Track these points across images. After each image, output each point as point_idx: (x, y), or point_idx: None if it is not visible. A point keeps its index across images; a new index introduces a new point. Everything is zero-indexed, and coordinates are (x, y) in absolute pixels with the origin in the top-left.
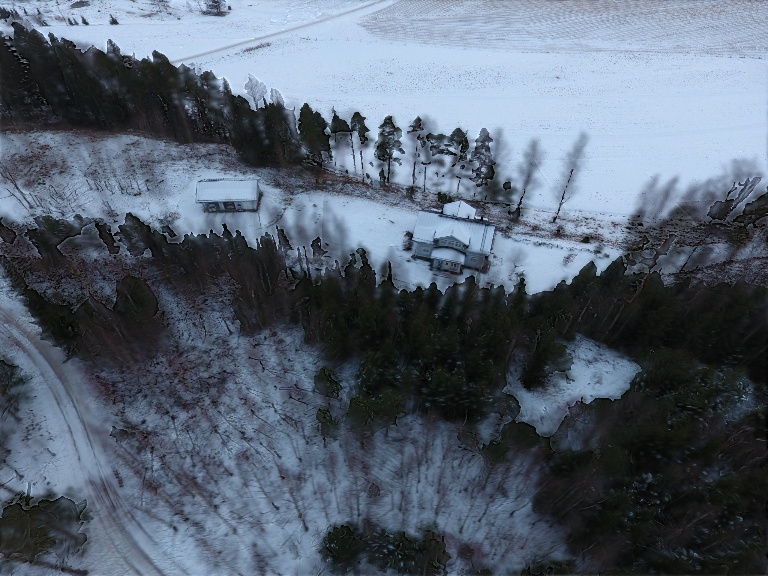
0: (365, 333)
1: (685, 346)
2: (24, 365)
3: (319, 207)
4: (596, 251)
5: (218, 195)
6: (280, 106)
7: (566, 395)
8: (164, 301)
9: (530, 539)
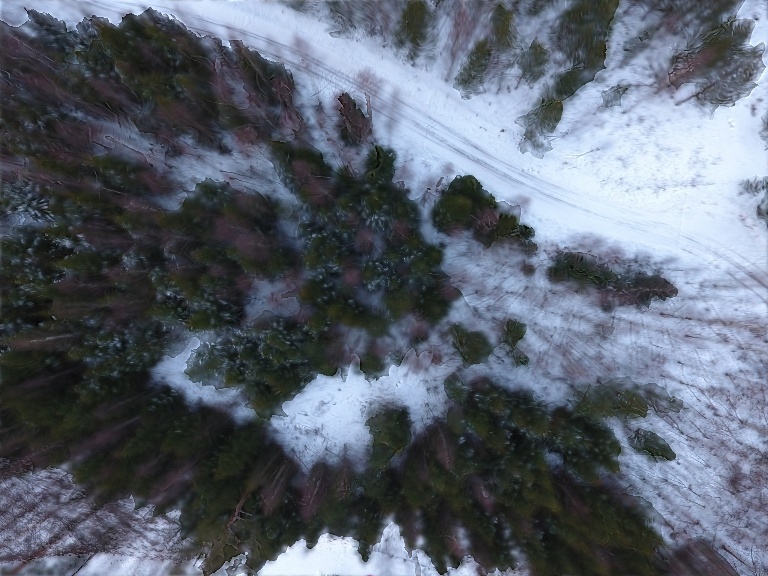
0: (607, 503)
1: (210, 425)
2: None
3: None
4: None
5: None
6: None
7: (367, 396)
8: None
9: (469, 270)
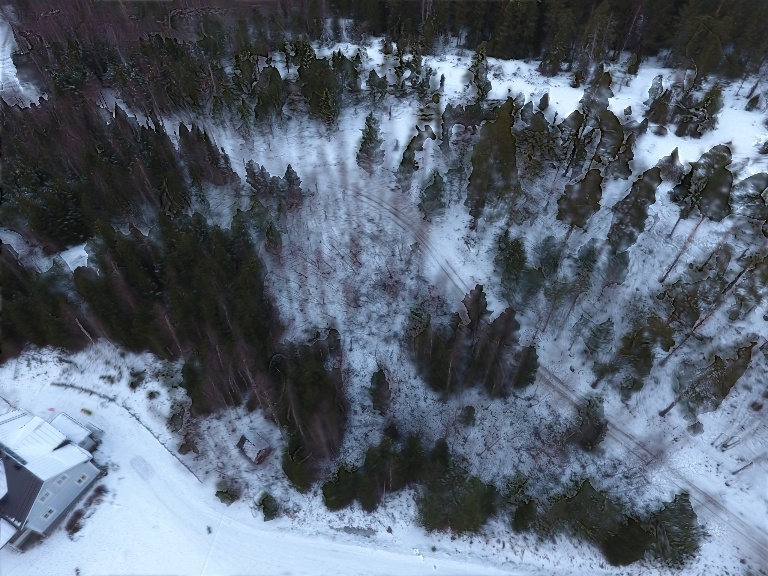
0: None
1: None
2: None
3: None
4: None
5: None
6: None
7: None
8: (430, 425)
9: None
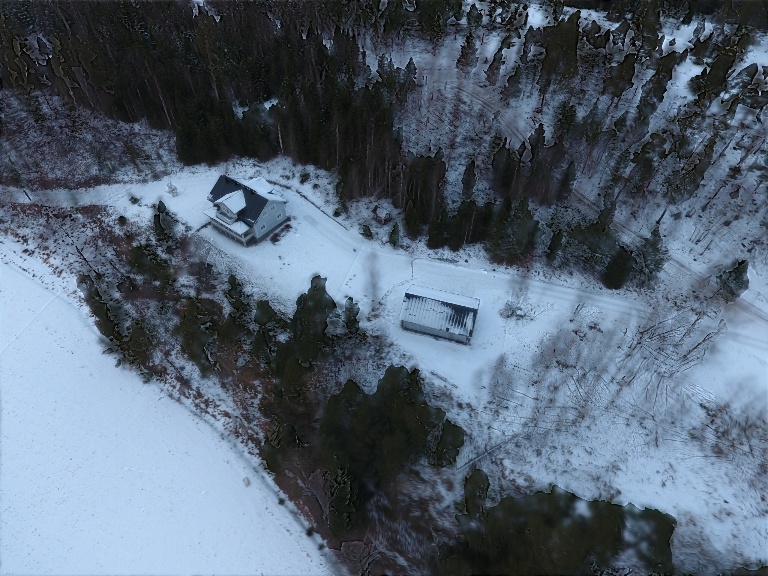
0: None
1: None
2: (574, 183)
3: (343, 294)
4: (134, 203)
5: (454, 296)
6: (333, 396)
7: None
8: None
9: None
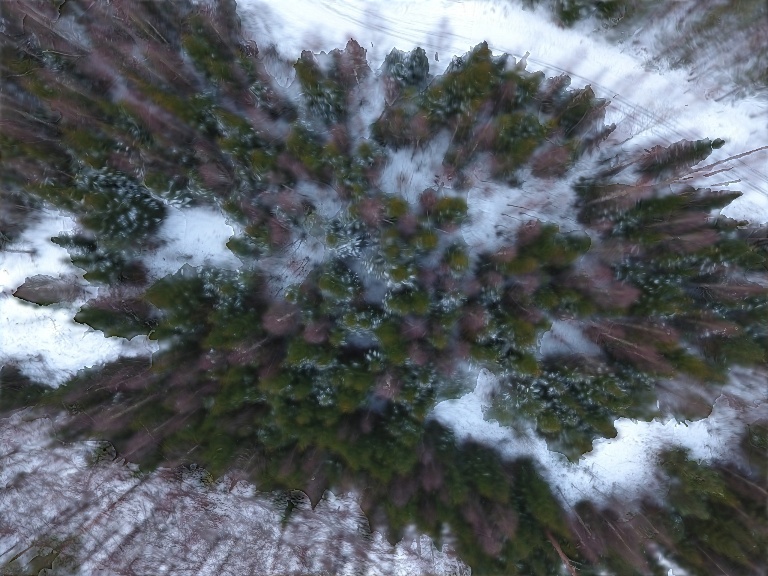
0: None
1: None
2: None
3: None
4: None
5: None
6: None
7: (644, 436)
8: None
9: None
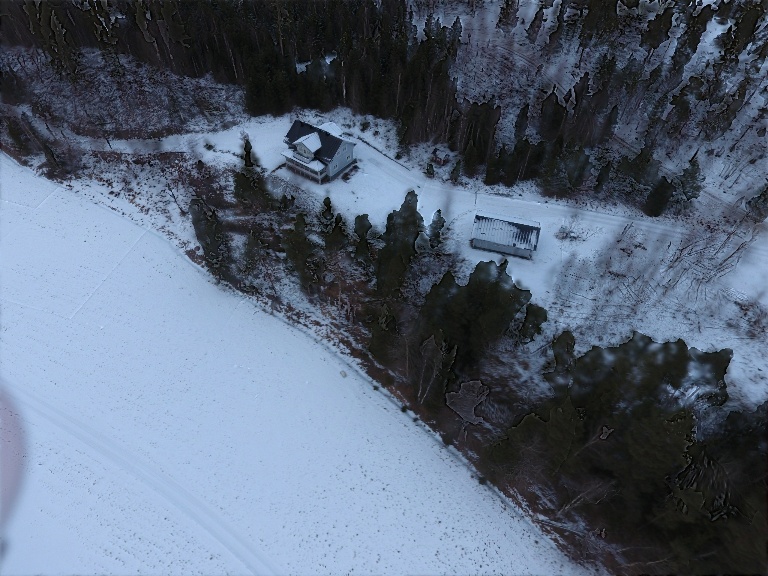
0: None
1: None
2: None
3: None
4: (209, 149)
5: (517, 219)
6: None
7: None
8: None
9: None
